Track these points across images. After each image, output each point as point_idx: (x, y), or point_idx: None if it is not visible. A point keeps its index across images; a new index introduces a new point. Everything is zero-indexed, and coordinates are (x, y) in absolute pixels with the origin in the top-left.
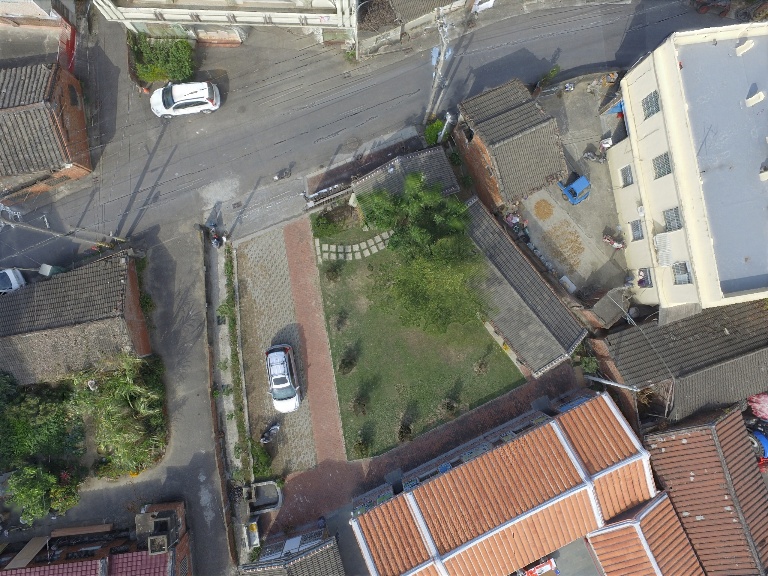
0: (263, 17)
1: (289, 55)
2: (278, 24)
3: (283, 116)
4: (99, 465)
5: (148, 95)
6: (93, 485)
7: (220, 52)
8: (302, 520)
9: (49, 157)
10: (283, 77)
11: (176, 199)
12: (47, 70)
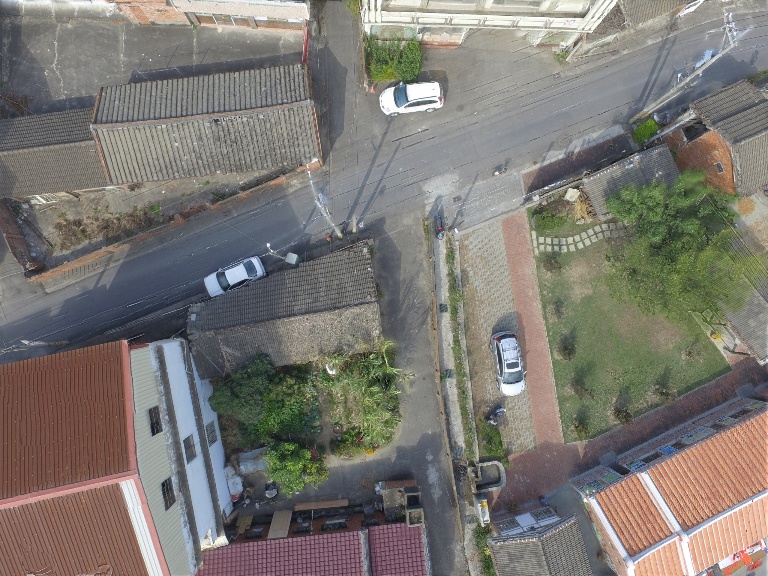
0: (513, 21)
1: (504, 56)
2: (522, 27)
3: (499, 115)
4: (339, 443)
5: (373, 94)
6: (329, 462)
7: (440, 53)
8: (522, 499)
9: (303, 152)
10: (498, 77)
11: (400, 193)
12: (300, 70)
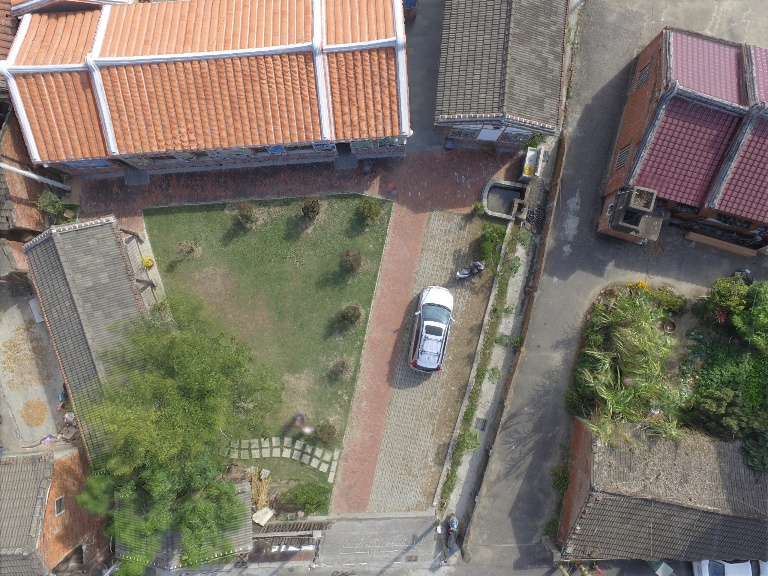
0: None
1: None
2: None
3: None
4: (678, 312)
5: None
6: (692, 290)
7: None
8: (471, 156)
9: None
10: None
11: None
12: None
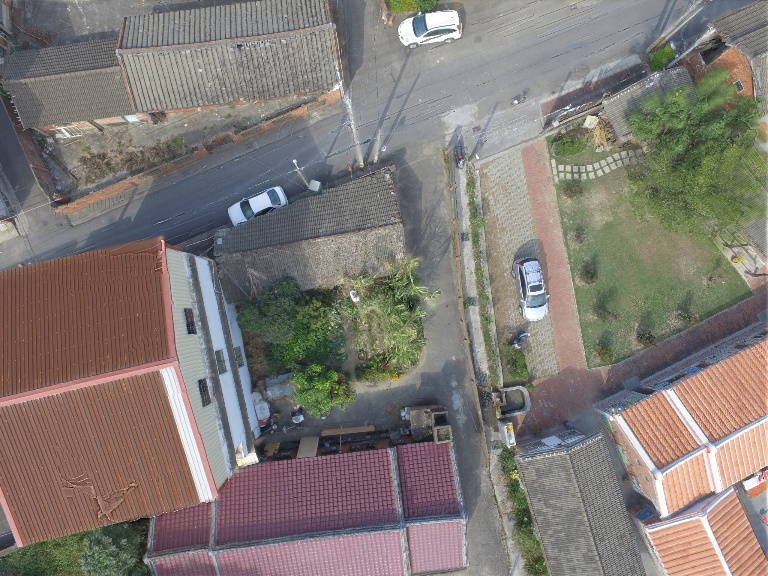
0: None
1: None
2: None
3: (516, 46)
4: (364, 369)
5: (392, 27)
6: None
7: None
8: (547, 424)
9: (325, 78)
10: (515, 9)
11: (420, 124)
12: None
